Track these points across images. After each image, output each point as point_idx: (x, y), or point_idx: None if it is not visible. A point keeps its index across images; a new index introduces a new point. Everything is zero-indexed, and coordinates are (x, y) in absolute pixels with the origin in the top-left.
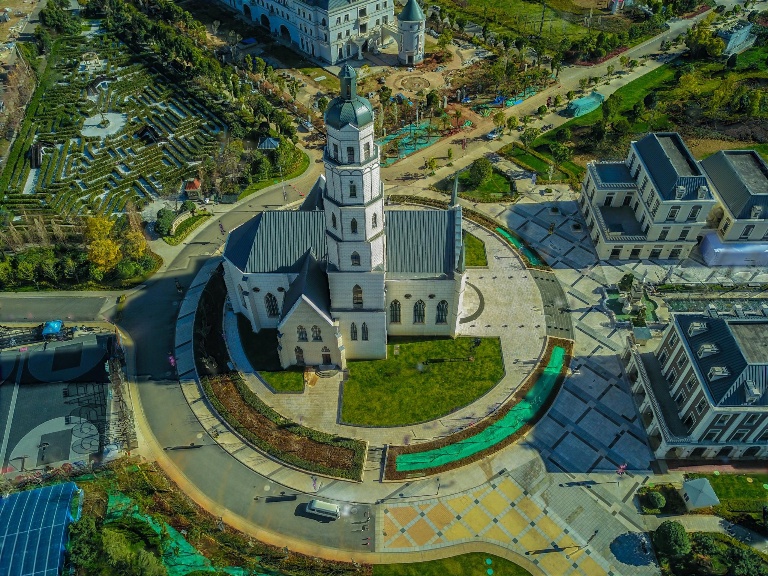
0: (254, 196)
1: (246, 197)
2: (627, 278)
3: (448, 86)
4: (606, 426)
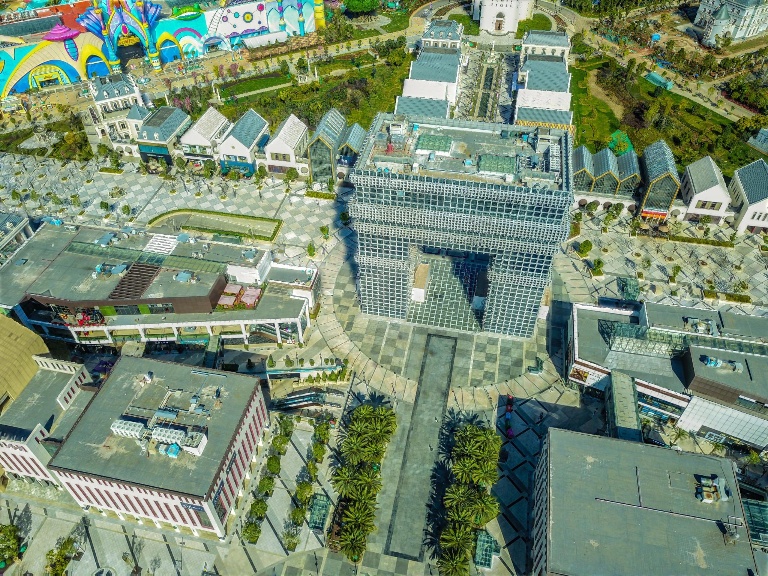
0: (566, 8)
1: (565, 7)
2: None
3: (676, 50)
4: None
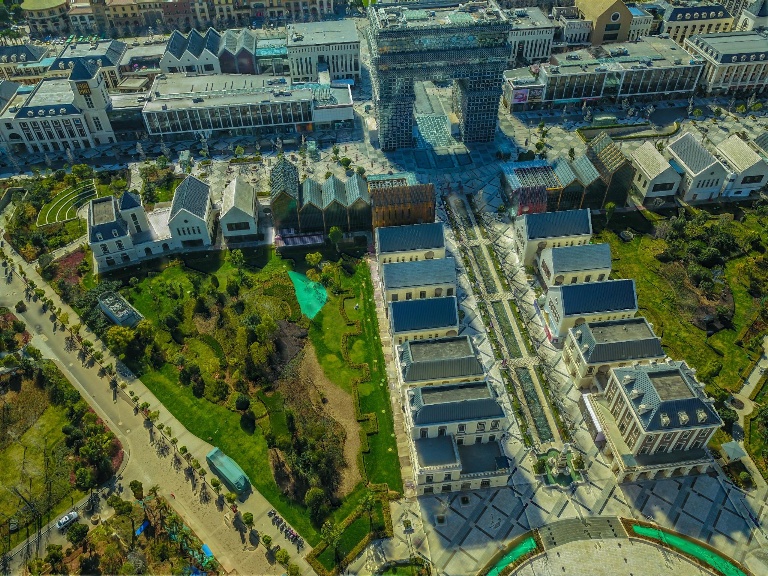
0: None
1: None
2: (543, 464)
3: None
4: (695, 502)
